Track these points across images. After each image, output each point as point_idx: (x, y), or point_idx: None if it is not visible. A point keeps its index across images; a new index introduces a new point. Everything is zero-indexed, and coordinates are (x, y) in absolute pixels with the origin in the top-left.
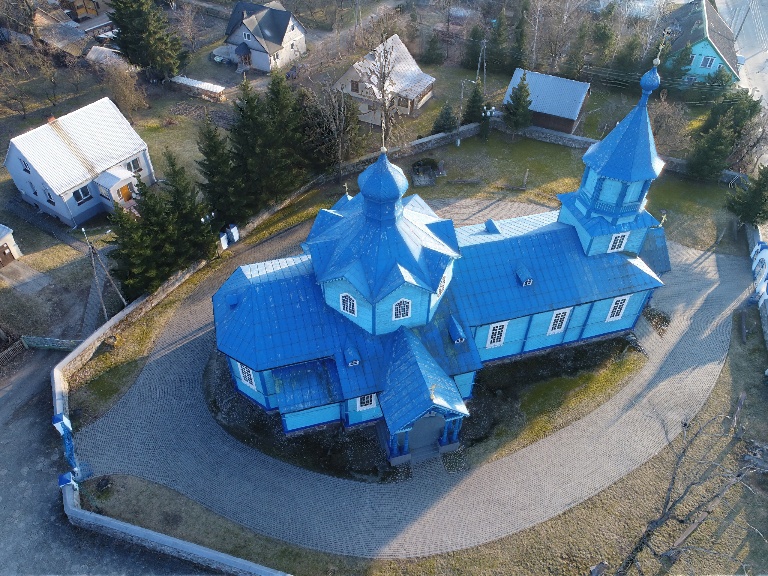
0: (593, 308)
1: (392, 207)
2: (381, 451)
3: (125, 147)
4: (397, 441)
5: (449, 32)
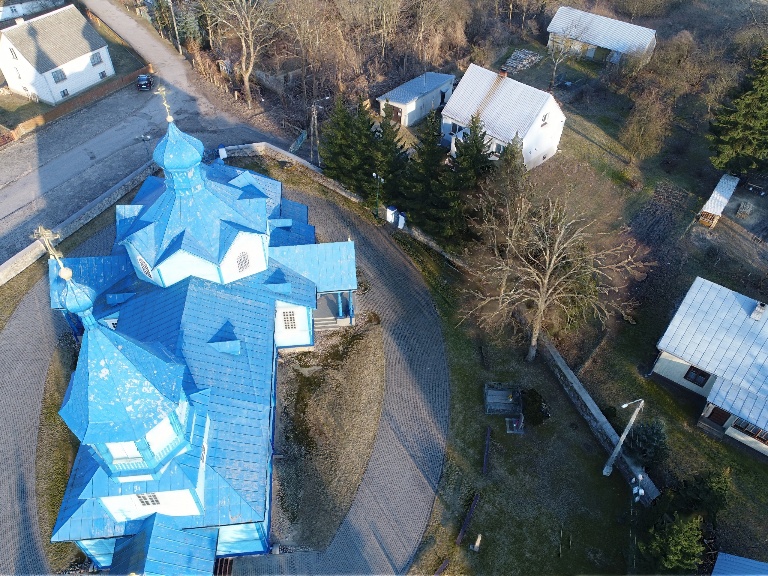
0: None
1: None
2: None
3: (508, 132)
4: None
5: None
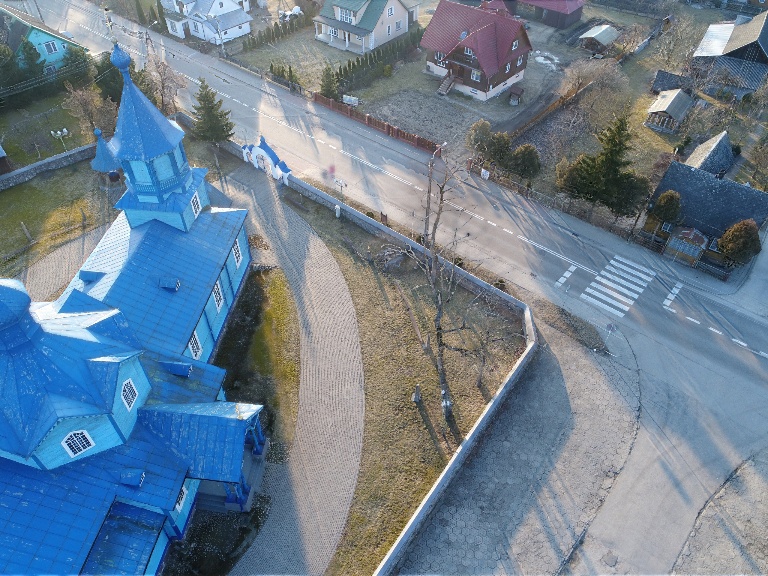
0: (226, 265)
1: (29, 317)
2: (228, 515)
3: None
4: (231, 492)
5: None
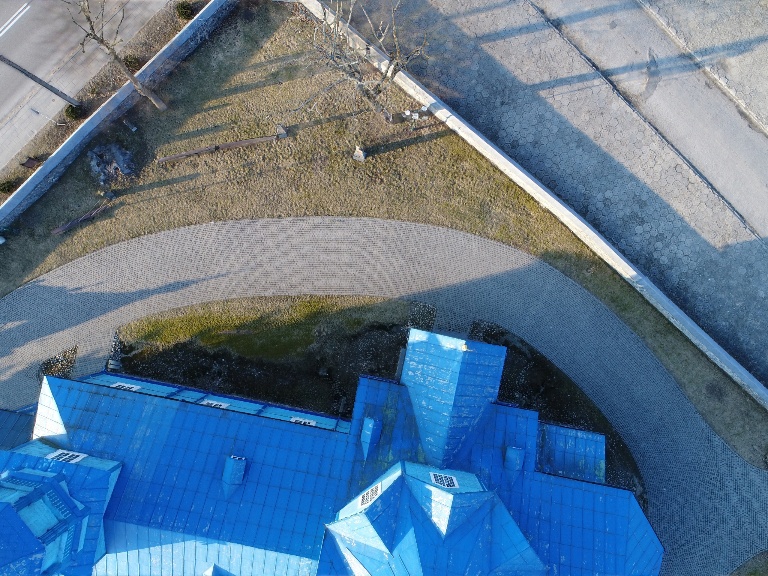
0: None
1: None
2: None
3: None
4: None
5: None
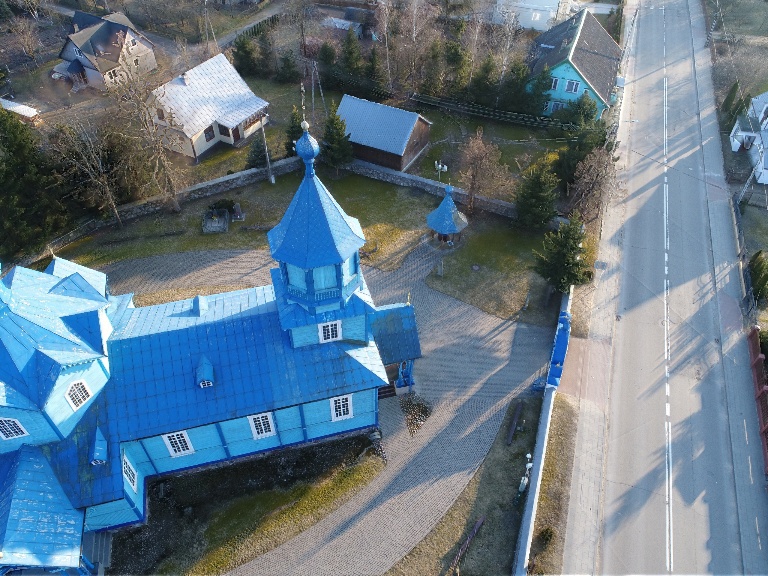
0: (305, 409)
1: None
2: None
3: None
4: None
5: (284, 51)
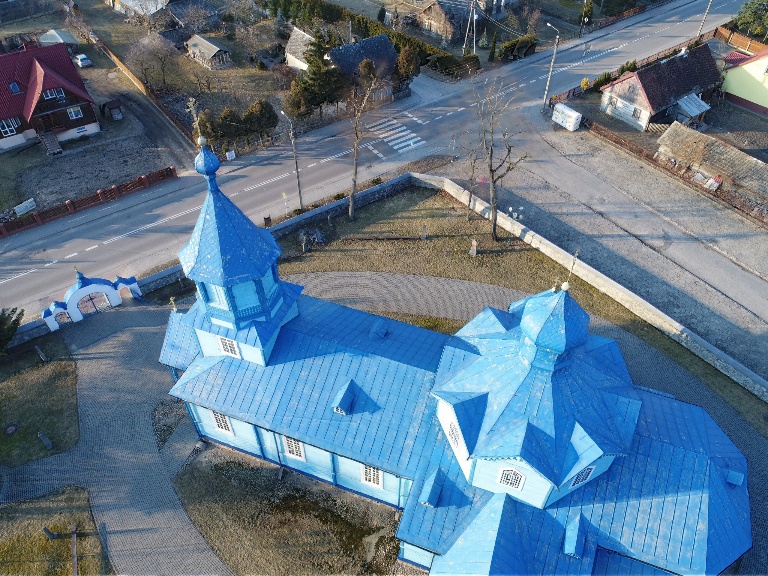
0: None
1: None
2: None
3: None
4: None
5: None
